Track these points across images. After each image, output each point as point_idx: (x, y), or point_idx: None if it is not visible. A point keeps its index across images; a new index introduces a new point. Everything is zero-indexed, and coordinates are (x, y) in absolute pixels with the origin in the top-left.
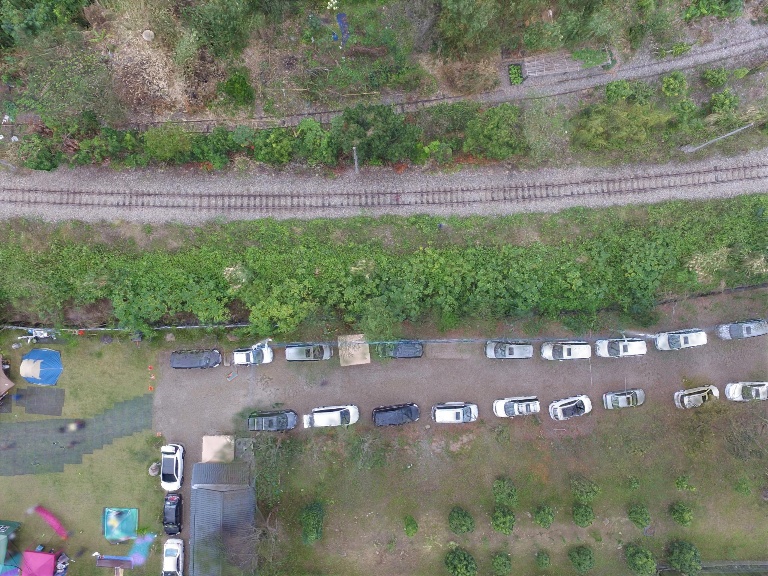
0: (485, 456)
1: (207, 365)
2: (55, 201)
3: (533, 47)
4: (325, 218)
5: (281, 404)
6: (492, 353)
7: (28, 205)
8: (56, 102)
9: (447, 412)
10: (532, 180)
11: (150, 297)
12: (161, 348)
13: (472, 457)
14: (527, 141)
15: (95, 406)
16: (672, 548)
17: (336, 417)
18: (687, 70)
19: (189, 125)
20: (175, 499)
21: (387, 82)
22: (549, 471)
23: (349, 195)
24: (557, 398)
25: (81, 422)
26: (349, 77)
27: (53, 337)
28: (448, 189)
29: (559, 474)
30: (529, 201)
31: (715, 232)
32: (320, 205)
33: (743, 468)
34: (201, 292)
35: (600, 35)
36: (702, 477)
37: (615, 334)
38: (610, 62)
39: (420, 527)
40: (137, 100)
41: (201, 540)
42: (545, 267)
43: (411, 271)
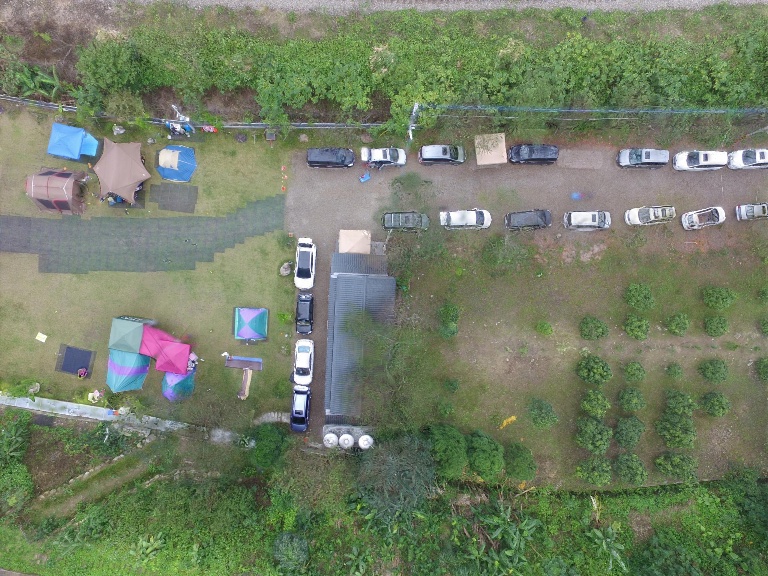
0: (615, 267)
1: (343, 162)
2: None
3: None
4: (468, 10)
5: (430, 182)
6: (626, 159)
7: None
8: None
9: (583, 214)
10: None
11: (296, 79)
12: (294, 149)
13: (602, 268)
14: None
15: (228, 204)
16: None
17: (472, 216)
18: None
19: None
20: (308, 296)
21: None
22: (679, 285)
23: None
24: (688, 211)
25: (213, 220)
26: None
27: (187, 134)
28: None
29: (689, 288)
30: None
31: None
32: None
33: None
34: (349, 73)
35: None
36: None
37: (747, 148)
38: None
39: (550, 336)
40: None
41: (341, 326)
42: (690, 60)
43: (557, 59)
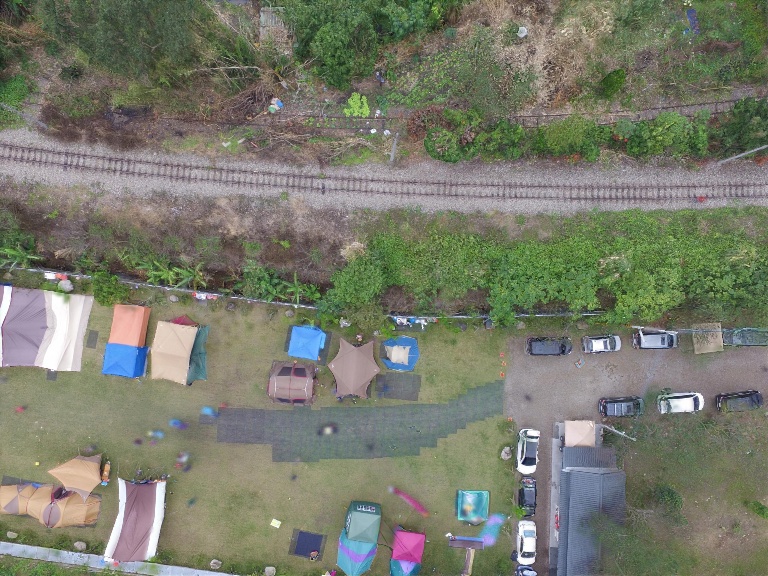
0: None
1: (563, 352)
2: (433, 193)
3: None
4: (692, 209)
5: (670, 389)
6: None
7: (408, 196)
8: (424, 97)
9: None
10: None
11: (532, 285)
12: (512, 336)
13: None
14: None
15: (450, 392)
16: None
17: (690, 403)
18: None
19: (549, 119)
20: (532, 482)
21: (736, 77)
22: None
23: (714, 187)
24: None
25: (436, 407)
26: (701, 72)
27: (410, 325)
28: None
29: None
30: None
31: None
32: (686, 196)
33: None
34: (585, 281)
35: None
36: None
37: None
38: None
39: None
40: (504, 95)
41: (577, 521)
42: None
43: None
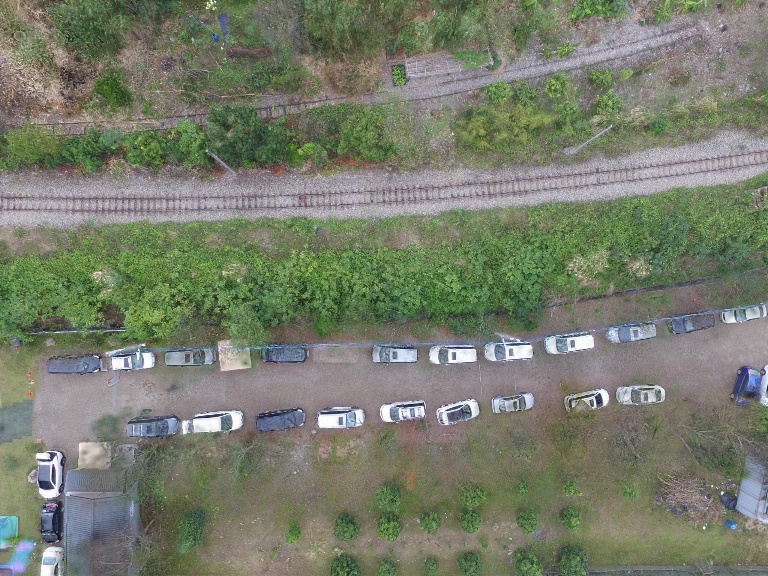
0: (373, 461)
1: (86, 370)
2: None
3: (418, 48)
4: (201, 221)
5: (149, 410)
6: (377, 357)
7: None
8: None
9: (330, 417)
10: (412, 182)
11: (19, 302)
12: (41, 353)
13: (360, 462)
14: (412, 143)
15: None
16: (562, 553)
17: (216, 423)
18: (574, 71)
19: (66, 127)
20: (53, 506)
21: (269, 83)
22: (438, 476)
23: (225, 198)
24: (446, 402)
25: None
26: (230, 78)
27: None
28: (326, 192)
29: (448, 479)
30: (408, 204)
31: (596, 235)
32: (196, 208)
33: (635, 472)
34: (69, 297)
35: (476, 36)
36: (594, 481)
37: (505, 338)
38: (492, 63)
39: (306, 533)
40: (11, 102)
41: (73, 548)
42: (423, 270)
43: (285, 275)
